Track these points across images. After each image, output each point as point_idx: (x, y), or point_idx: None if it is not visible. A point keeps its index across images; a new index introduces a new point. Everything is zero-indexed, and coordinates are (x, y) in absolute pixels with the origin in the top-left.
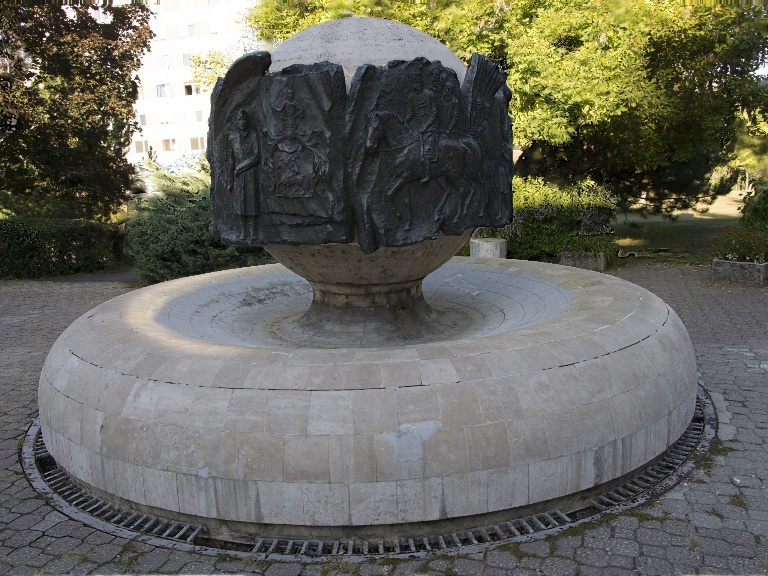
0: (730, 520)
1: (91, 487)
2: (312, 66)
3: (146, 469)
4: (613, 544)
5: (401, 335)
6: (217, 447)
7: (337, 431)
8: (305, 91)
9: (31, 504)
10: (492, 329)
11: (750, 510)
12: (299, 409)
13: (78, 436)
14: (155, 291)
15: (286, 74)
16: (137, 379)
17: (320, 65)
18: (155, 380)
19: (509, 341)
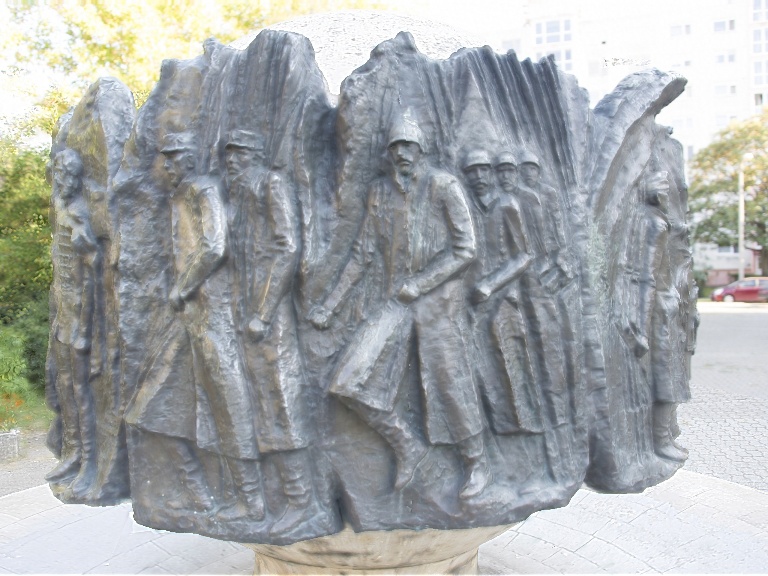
0: None
1: None
2: None
3: None
4: None
5: None
6: None
7: None
8: None
9: None
10: None
11: None
12: None
13: None
14: None
15: None
16: None
17: None
18: None
19: (686, 475)
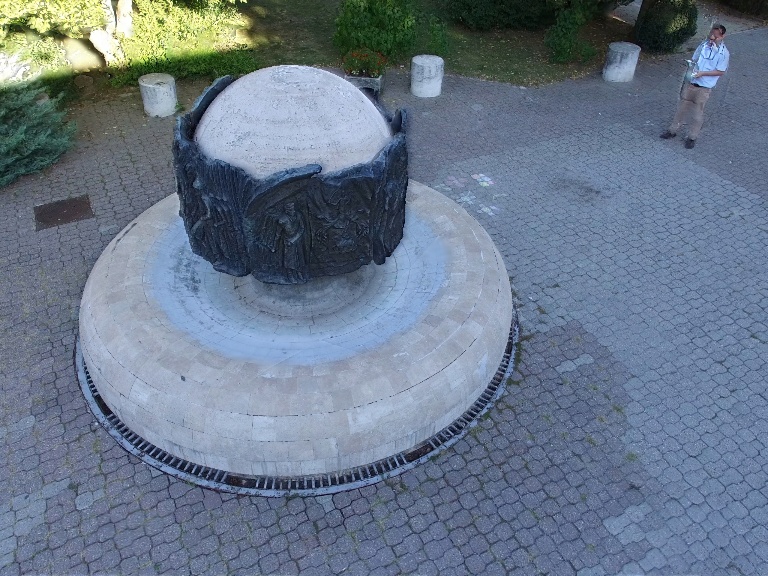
0: (549, 323)
1: (313, 474)
2: (353, 170)
3: (376, 448)
4: (534, 359)
5: (353, 282)
6: (416, 419)
7: (461, 381)
8: (351, 188)
9: (296, 504)
10: (392, 255)
11: (549, 314)
12: (444, 382)
13: (312, 457)
14: (145, 321)
15: (336, 179)
16: (346, 411)
17: (358, 168)
18: (359, 406)
19: (471, 289)
